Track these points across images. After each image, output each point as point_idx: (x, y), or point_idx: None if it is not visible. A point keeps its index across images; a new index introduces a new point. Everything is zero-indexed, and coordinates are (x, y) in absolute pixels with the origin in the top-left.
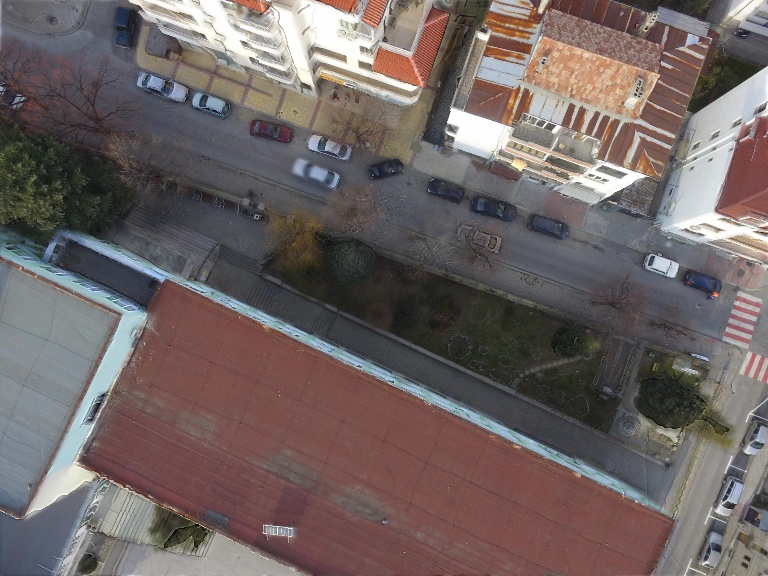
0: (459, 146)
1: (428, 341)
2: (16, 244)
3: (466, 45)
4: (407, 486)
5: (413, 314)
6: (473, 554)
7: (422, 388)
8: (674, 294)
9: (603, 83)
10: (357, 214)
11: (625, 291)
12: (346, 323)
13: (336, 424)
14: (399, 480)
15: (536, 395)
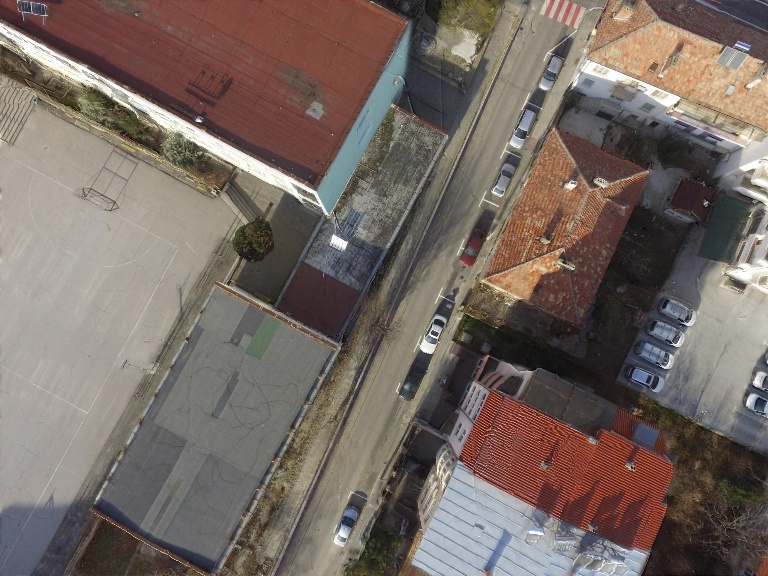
0: None
1: None
2: None
3: None
4: None
5: None
6: (218, 47)
7: None
8: None
9: None
10: None
11: None
12: None
13: None
14: None
15: None
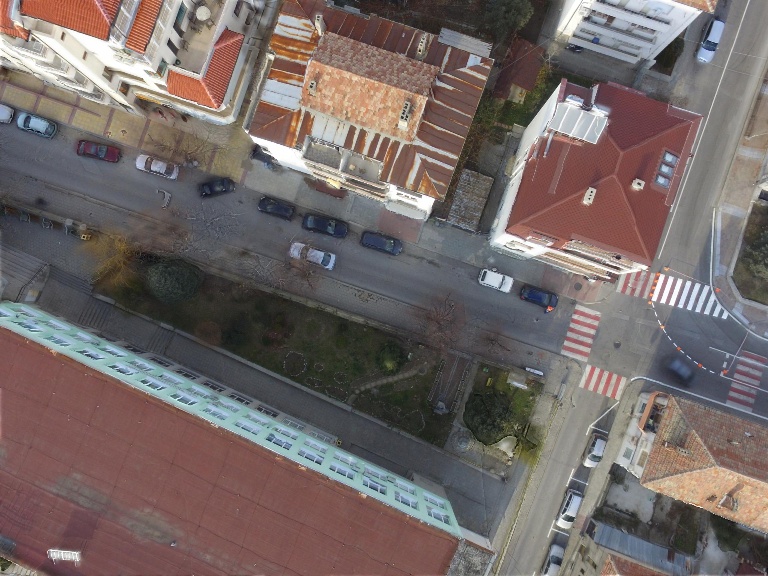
0: (285, 164)
1: (264, 358)
2: None
3: (258, 67)
4: (196, 509)
5: (247, 332)
6: (261, 575)
7: (245, 407)
8: (511, 308)
9: (375, 106)
10: (188, 233)
11: (447, 308)
12: (184, 341)
13: (125, 448)
14: (188, 503)
15: (372, 411)
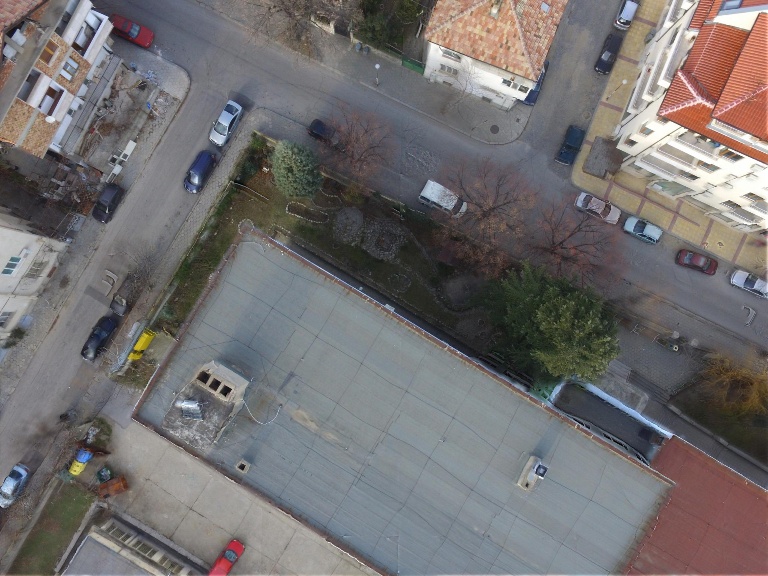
0: None
1: None
2: (543, 390)
3: None
4: None
5: None
6: None
7: None
8: None
9: None
10: None
11: None
12: (731, 457)
13: None
14: None
15: None
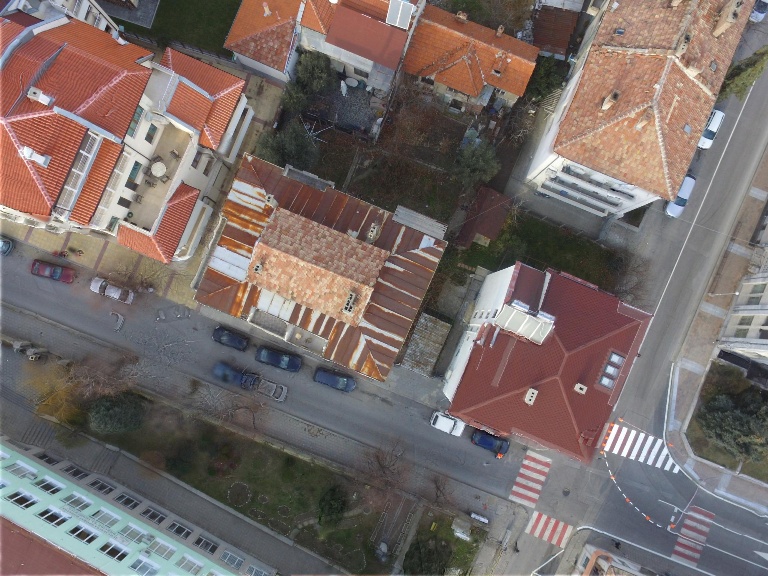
0: None
1: (208, 486)
2: None
3: (211, 226)
4: None
5: (192, 460)
6: None
7: (182, 545)
8: (462, 451)
9: (321, 290)
10: (139, 358)
11: (393, 459)
12: (130, 462)
13: None
14: None
15: (314, 547)
